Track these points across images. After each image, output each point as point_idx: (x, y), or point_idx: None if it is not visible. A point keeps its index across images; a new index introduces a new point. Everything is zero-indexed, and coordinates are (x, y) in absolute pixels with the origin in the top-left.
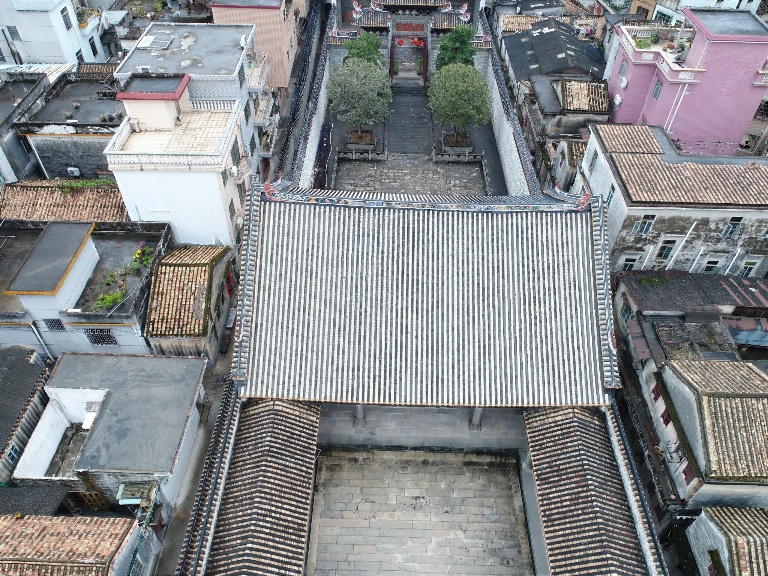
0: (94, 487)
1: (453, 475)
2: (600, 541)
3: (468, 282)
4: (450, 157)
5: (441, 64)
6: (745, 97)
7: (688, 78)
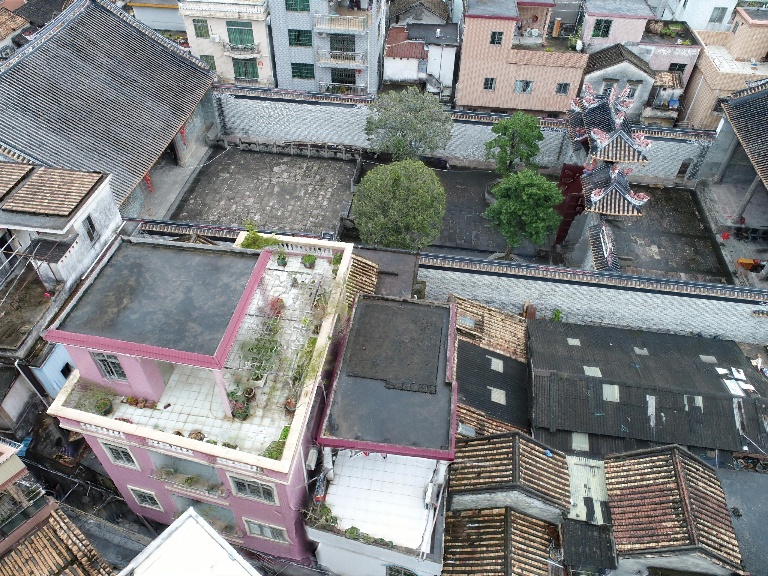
0: None
1: None
2: None
3: None
4: None
5: (498, 198)
6: None
7: None
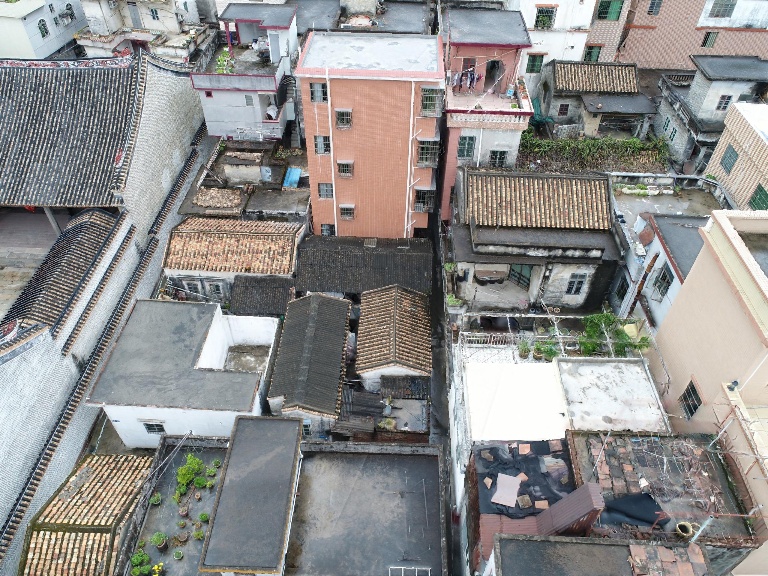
0: None
1: None
2: None
3: None
4: None
5: None
6: None
7: None
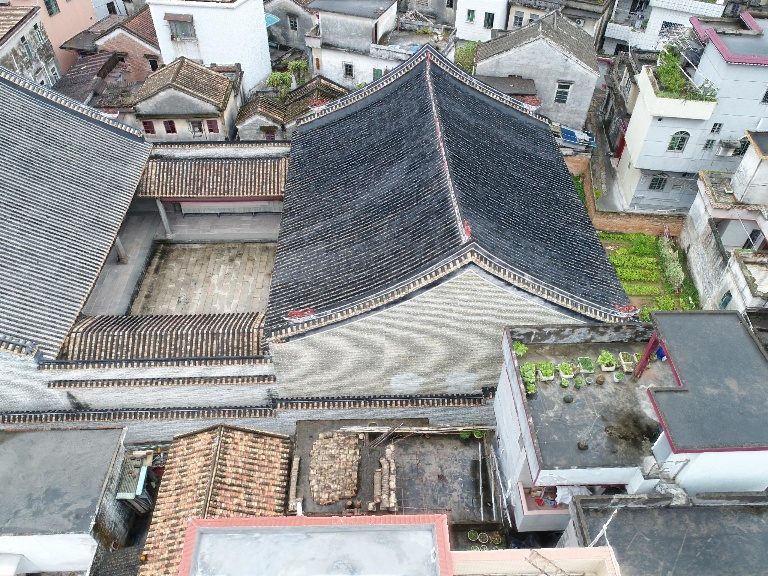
0: (108, 539)
1: (164, 280)
2: (248, 164)
3: (8, 164)
4: None
5: None
6: None
7: None
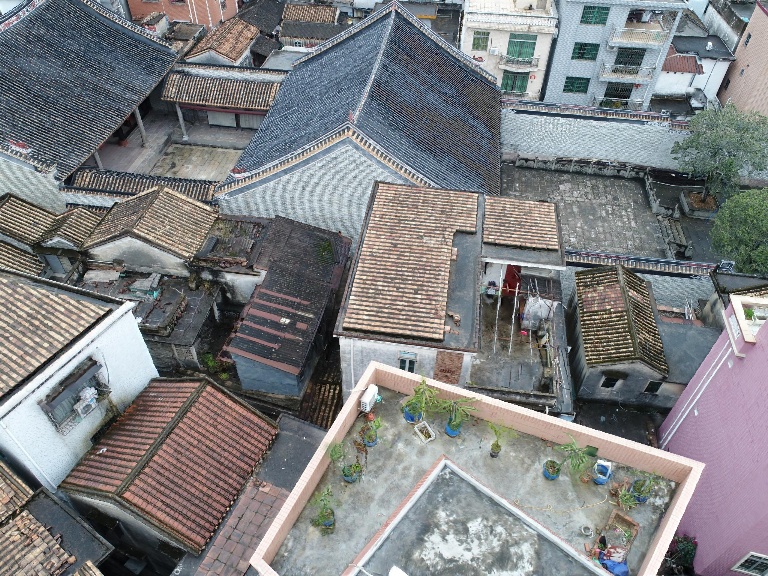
0: None
1: None
2: None
3: None
4: (671, 257)
5: None
6: (761, 469)
7: (735, 332)
